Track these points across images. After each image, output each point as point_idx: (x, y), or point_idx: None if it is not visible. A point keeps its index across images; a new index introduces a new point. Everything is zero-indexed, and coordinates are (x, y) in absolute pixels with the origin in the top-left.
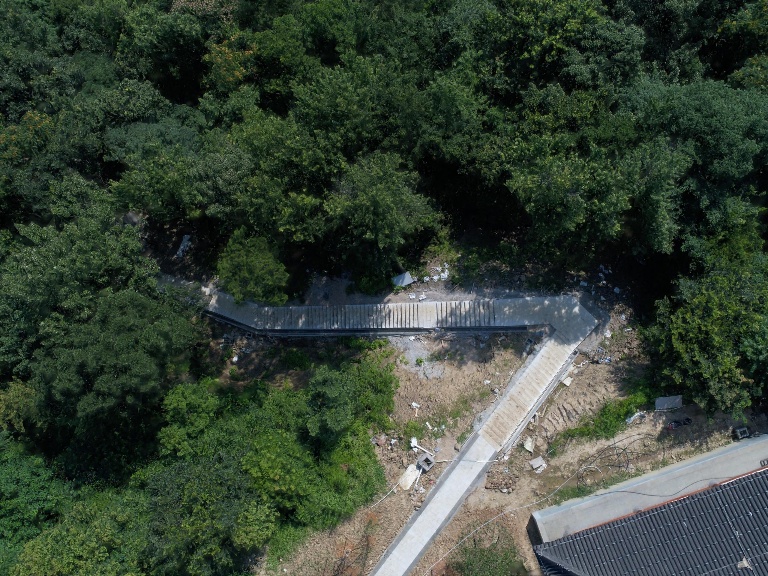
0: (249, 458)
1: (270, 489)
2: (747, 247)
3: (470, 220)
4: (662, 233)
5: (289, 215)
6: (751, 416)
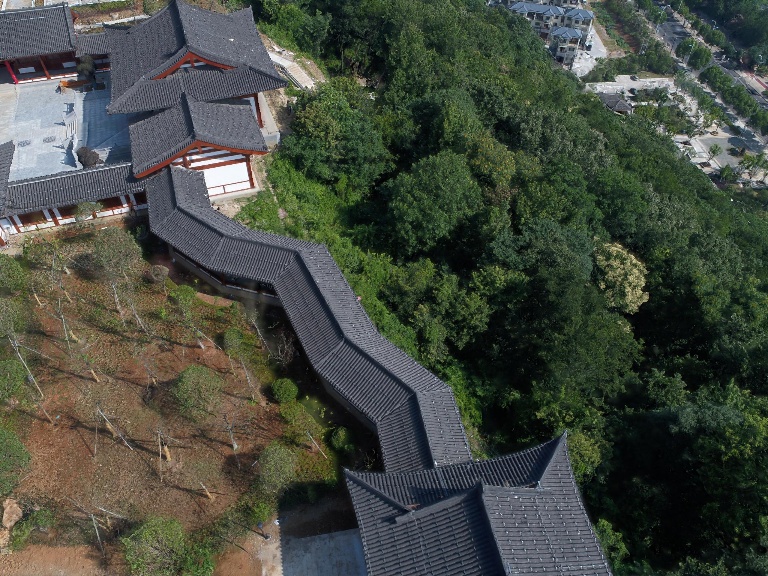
0: (296, 5)
1: None
2: None
3: None
4: None
5: None
6: None
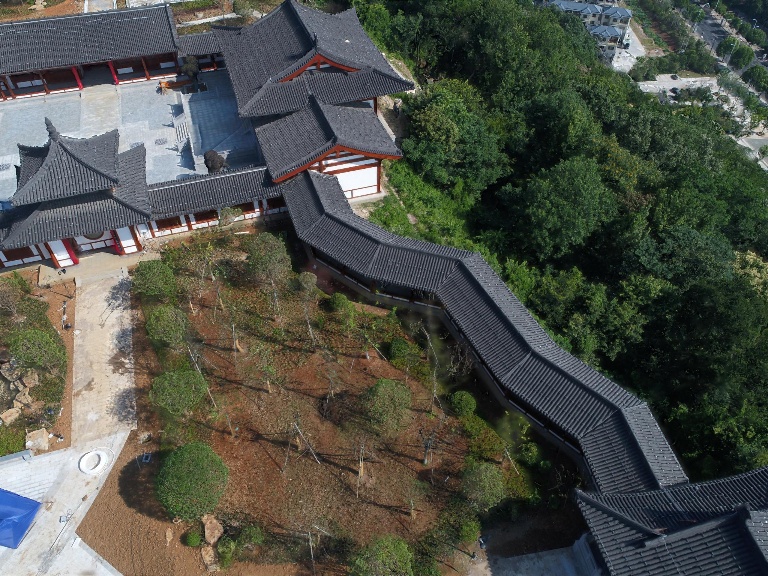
0: None
1: (370, 5)
2: None
3: None
4: None
5: (487, 0)
6: (399, 141)
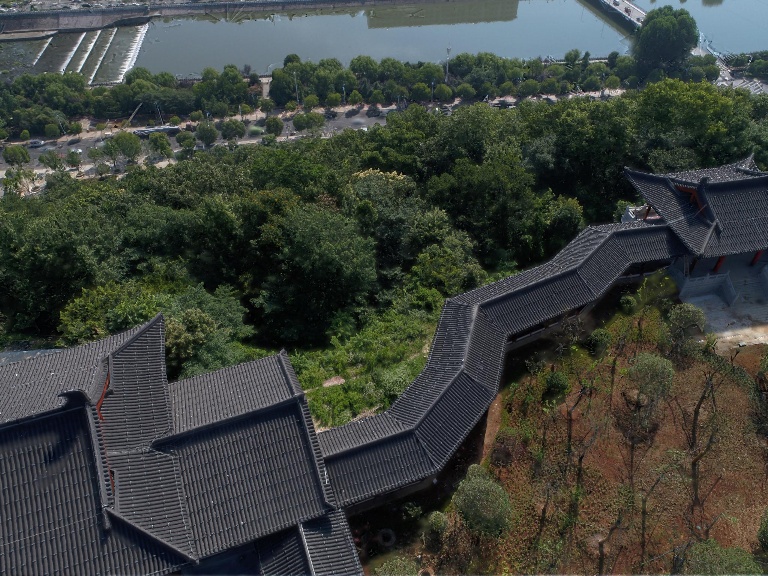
0: None
1: None
2: (173, 290)
3: (34, 332)
4: (93, 269)
5: None
6: None
